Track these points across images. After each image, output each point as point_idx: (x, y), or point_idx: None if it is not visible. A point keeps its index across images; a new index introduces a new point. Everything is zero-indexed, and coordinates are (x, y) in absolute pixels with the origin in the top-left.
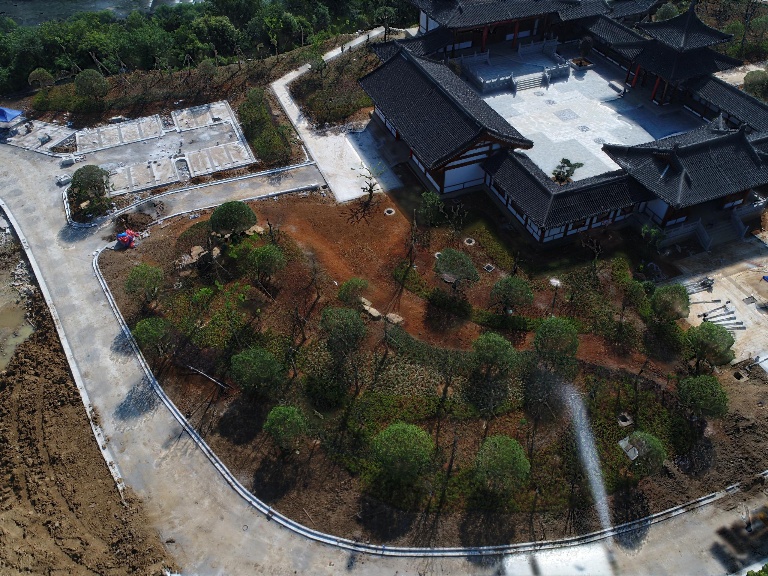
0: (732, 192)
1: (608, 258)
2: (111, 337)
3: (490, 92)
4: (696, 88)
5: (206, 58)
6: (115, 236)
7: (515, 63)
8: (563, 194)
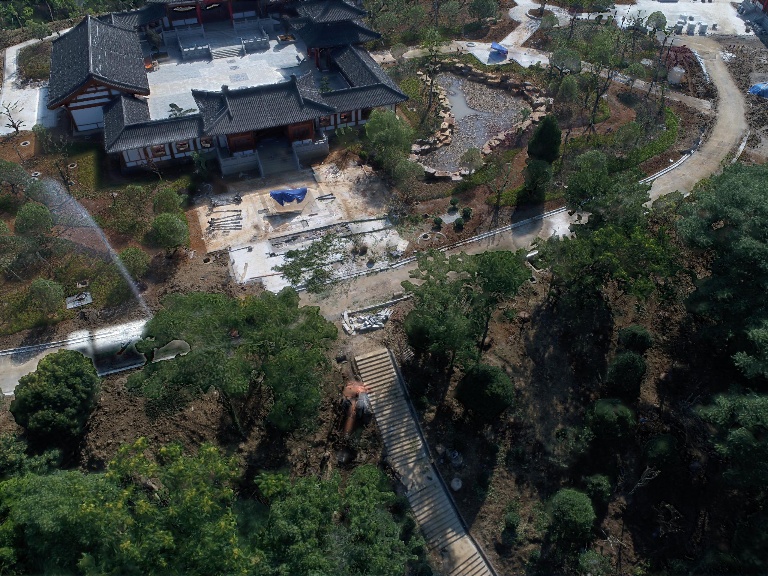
0: (267, 126)
1: (175, 180)
2: None
3: (191, 59)
4: (337, 56)
5: None
6: None
7: (228, 37)
8: (135, 126)
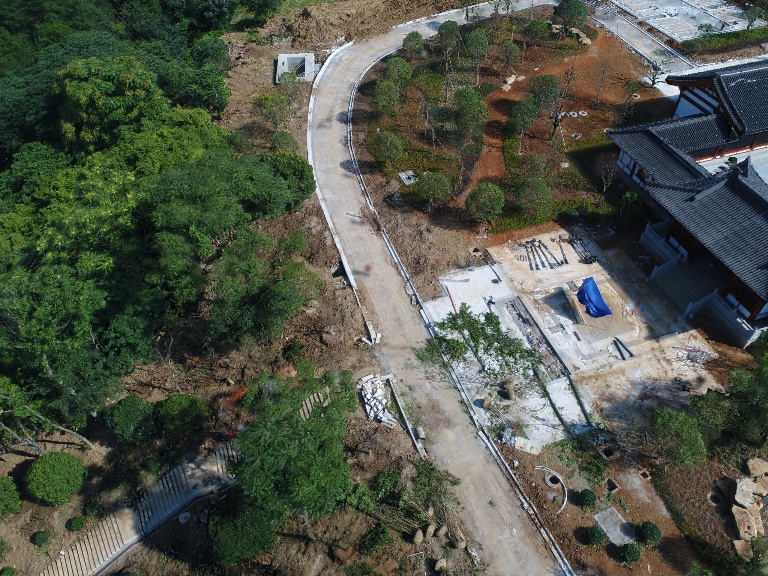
0: (700, 239)
1: (610, 203)
2: (484, 15)
3: None
4: None
5: None
6: None
7: None
8: (654, 136)
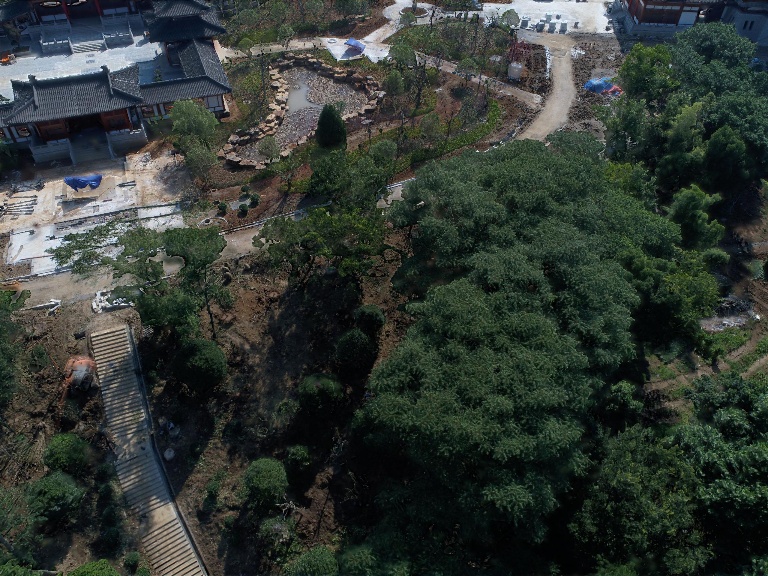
0: (71, 115)
1: None
2: None
3: (51, 53)
4: (181, 50)
5: None
6: None
7: (94, 32)
8: None
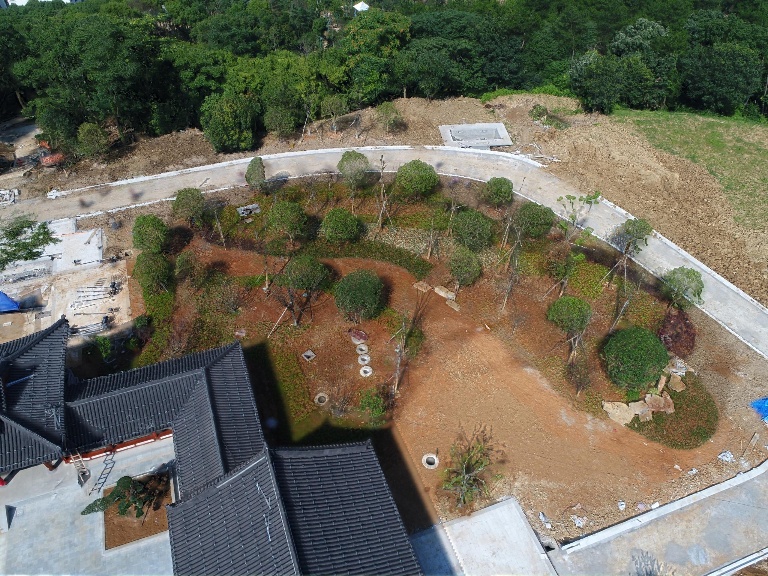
0: None
1: None
2: None
3: None
4: None
5: None
6: None
7: None
8: None
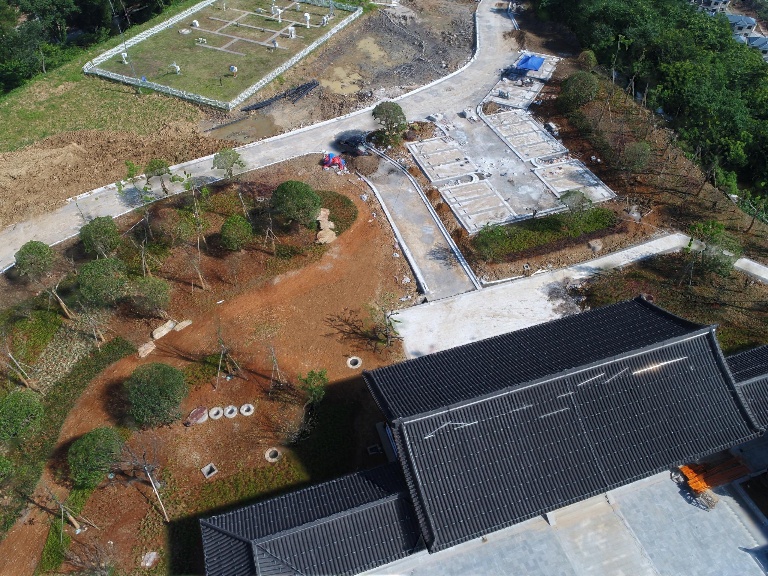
0: None
1: None
2: (214, 174)
3: None
4: None
5: (714, 162)
6: (342, 156)
7: None
8: None
